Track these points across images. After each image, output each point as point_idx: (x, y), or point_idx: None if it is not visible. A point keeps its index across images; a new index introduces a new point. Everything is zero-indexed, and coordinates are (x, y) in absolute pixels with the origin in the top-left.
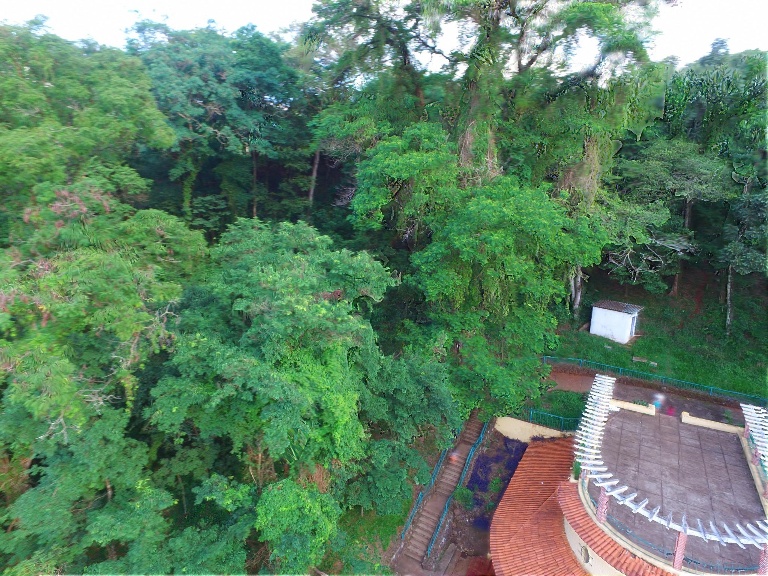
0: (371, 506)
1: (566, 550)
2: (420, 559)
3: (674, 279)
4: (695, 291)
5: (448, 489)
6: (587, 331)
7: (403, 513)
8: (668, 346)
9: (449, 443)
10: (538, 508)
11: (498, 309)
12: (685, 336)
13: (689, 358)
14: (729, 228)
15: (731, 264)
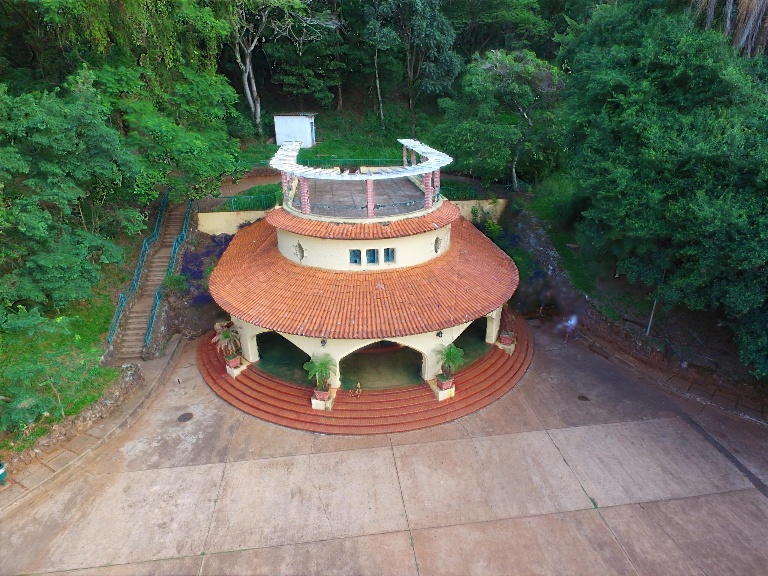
0: (44, 297)
1: (284, 262)
2: (139, 354)
3: (338, 94)
4: (356, 107)
5: (157, 288)
6: (274, 144)
7: (104, 320)
8: (343, 145)
9: (140, 225)
10: (253, 253)
11: (159, 58)
12: (354, 136)
13: (360, 148)
14: (368, 8)
15: (374, 41)
